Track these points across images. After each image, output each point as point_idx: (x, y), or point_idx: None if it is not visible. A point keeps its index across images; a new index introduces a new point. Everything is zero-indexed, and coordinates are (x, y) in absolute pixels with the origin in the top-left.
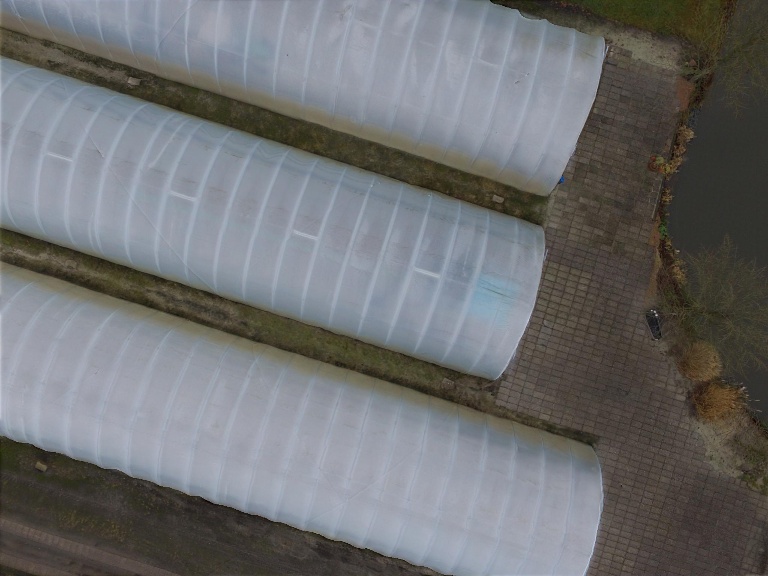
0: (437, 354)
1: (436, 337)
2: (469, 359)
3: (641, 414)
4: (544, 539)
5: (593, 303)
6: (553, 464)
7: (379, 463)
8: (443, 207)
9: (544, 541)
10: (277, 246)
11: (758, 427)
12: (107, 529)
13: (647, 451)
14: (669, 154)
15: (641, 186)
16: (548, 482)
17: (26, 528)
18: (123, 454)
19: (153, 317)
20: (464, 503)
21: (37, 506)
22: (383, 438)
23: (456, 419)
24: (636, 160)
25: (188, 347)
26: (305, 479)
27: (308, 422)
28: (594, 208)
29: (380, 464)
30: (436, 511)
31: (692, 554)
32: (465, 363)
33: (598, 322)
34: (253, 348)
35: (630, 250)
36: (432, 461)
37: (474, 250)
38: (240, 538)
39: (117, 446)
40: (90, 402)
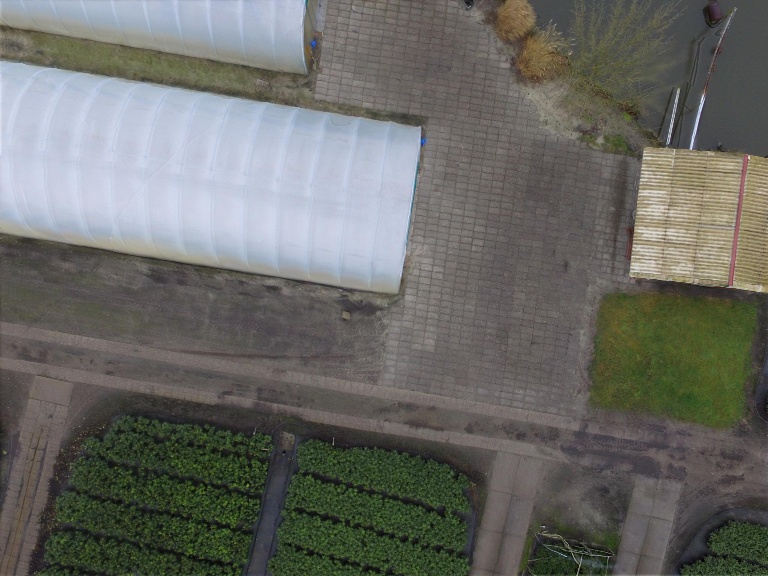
0: (236, 40)
1: (223, 9)
2: (265, 34)
3: (467, 88)
4: (360, 192)
5: None
6: (368, 128)
7: (175, 137)
8: None
9: (360, 194)
10: None
11: (592, 87)
12: None
13: (479, 125)
14: None
15: None
16: (361, 140)
17: None
18: None
19: None
20: (271, 166)
21: None
22: (179, 116)
23: (265, 104)
24: None
25: None
26: (99, 164)
27: (97, 109)
28: None
29: (176, 138)
30: (243, 180)
31: (542, 224)
32: (266, 45)
33: None
34: None
35: None
36: (234, 132)
37: None
38: (68, 276)
39: None
40: None
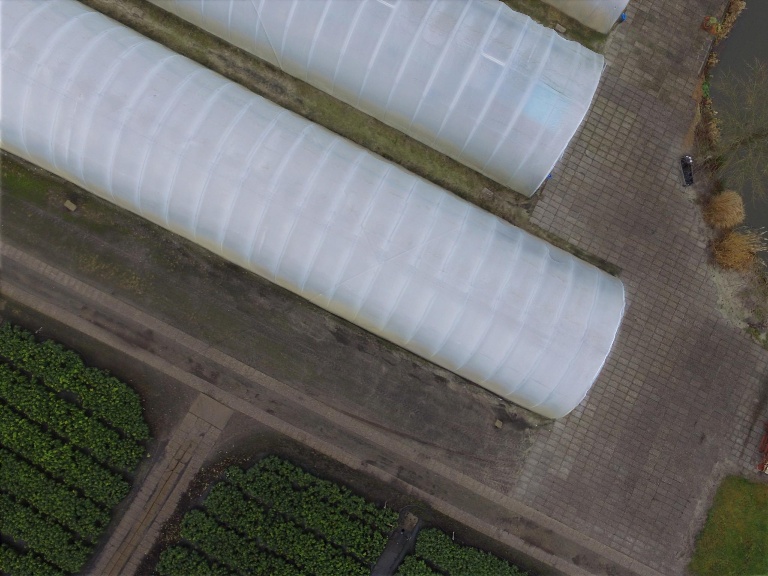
0: (485, 153)
1: (490, 128)
2: (516, 159)
3: (663, 254)
4: (566, 331)
5: (634, 142)
6: (581, 271)
7: (420, 232)
8: (514, 11)
9: (565, 333)
10: (355, 6)
11: (767, 287)
12: (127, 279)
13: (664, 290)
14: (721, 19)
15: (692, 42)
16: (575, 283)
17: (43, 264)
18: (166, 183)
19: (213, 73)
20: (495, 284)
21: (59, 244)
22: (426, 212)
23: (494, 218)
24: (691, 18)
25: (247, 98)
26: (346, 234)
27: (356, 183)
28: (647, 54)
29: (420, 233)
30: (467, 288)
31: (692, 395)
32: (510, 166)
33: (636, 161)
34: (307, 120)
35: (674, 99)
36: (470, 241)
37: (540, 48)
38: (260, 310)
39: (162, 173)
40: (144, 122)
